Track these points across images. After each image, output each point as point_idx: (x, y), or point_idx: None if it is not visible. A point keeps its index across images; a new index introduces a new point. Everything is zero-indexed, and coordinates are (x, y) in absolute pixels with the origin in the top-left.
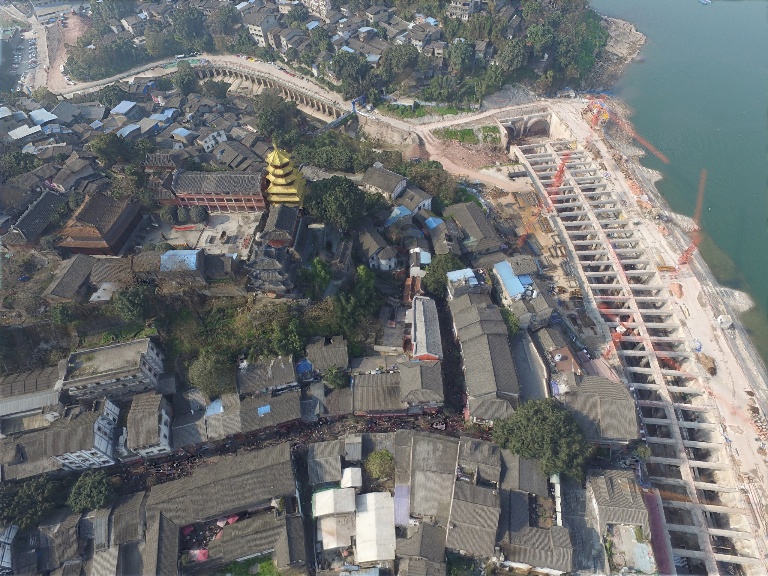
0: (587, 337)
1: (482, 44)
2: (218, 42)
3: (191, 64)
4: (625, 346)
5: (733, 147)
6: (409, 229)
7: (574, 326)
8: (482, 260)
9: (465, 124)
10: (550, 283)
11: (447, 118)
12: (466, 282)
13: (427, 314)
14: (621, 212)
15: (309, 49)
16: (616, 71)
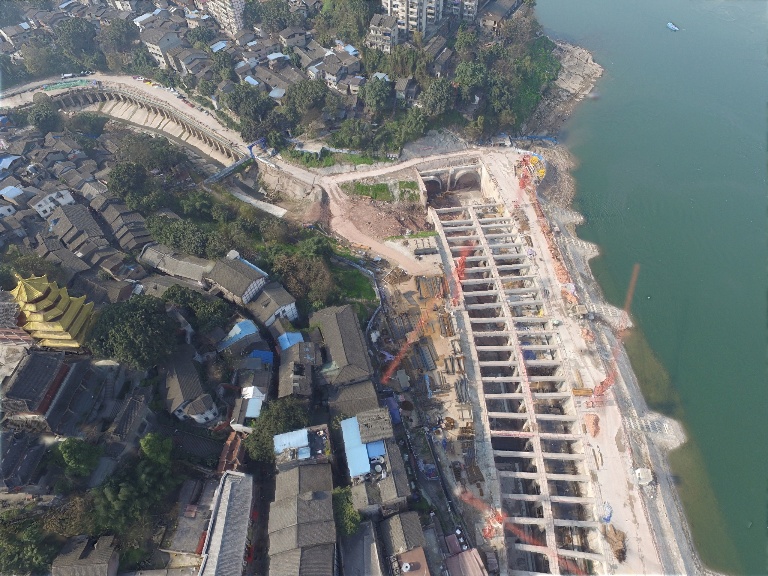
0: (470, 499)
1: (403, 83)
2: (110, 61)
3: (79, 86)
4: (527, 492)
5: (683, 215)
6: (251, 353)
7: (456, 481)
8: (343, 395)
9: (379, 177)
10: (438, 413)
11: (360, 168)
12: (293, 455)
13: (234, 504)
14: (542, 305)
15: (210, 76)
16: (565, 111)
